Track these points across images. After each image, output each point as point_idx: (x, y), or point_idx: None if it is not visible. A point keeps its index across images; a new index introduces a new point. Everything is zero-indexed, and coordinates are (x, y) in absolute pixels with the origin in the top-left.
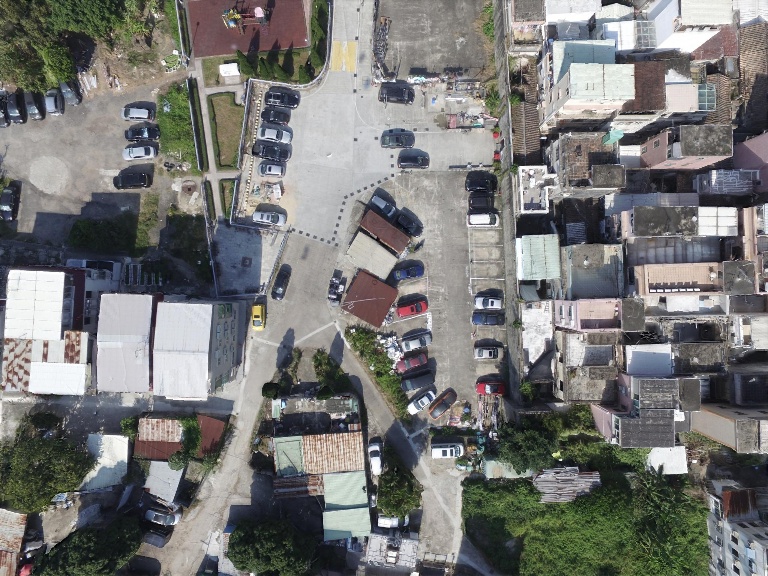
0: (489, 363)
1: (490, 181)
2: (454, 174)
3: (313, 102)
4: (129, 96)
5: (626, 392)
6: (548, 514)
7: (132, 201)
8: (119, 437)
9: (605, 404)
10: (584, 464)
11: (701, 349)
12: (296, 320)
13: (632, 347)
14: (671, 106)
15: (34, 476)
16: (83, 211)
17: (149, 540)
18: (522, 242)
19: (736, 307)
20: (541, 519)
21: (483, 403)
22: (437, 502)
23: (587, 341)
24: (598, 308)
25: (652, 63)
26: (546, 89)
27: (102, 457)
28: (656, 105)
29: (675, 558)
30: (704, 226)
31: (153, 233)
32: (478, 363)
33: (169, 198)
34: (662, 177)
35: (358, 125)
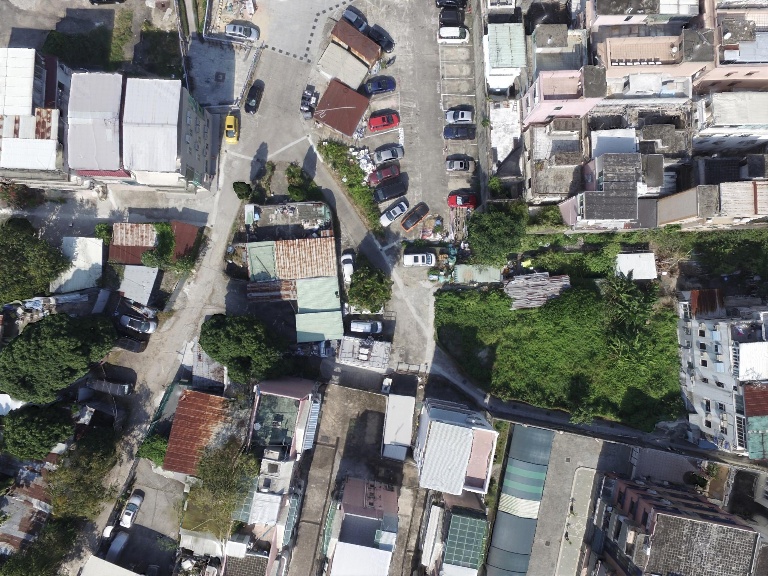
0: (461, 178)
1: None
2: None
3: None
4: None
5: (592, 178)
6: (519, 322)
7: (106, 17)
8: (93, 239)
9: None
10: (554, 270)
11: (664, 130)
12: (269, 134)
13: (597, 133)
14: None
15: (7, 258)
16: (58, 26)
17: (124, 344)
18: (488, 30)
19: None
20: (513, 327)
21: (455, 217)
22: (410, 313)
23: (553, 128)
24: (561, 84)
25: None
26: None
27: (77, 259)
28: None
29: (644, 354)
30: (665, 4)
31: (127, 48)
32: (450, 178)
33: (143, 14)
34: None
35: None
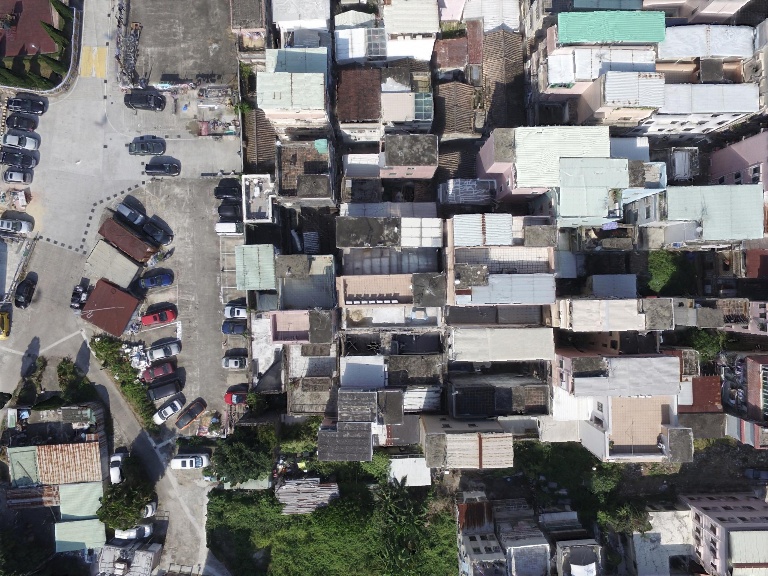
0: (240, 373)
1: (238, 189)
2: (206, 182)
3: (62, 108)
4: None
5: None
6: (293, 525)
7: None
8: None
9: (330, 416)
10: (326, 475)
11: (410, 361)
12: (42, 329)
13: (346, 359)
14: (386, 115)
15: None
16: None
17: None
18: (235, 252)
19: (469, 318)
20: (286, 531)
21: (233, 413)
22: (183, 513)
23: (301, 352)
24: (297, 320)
25: (368, 71)
26: None
27: None
28: (371, 114)
29: (406, 571)
30: (407, 237)
31: None
32: (229, 373)
33: None
34: (401, 186)
35: (108, 132)
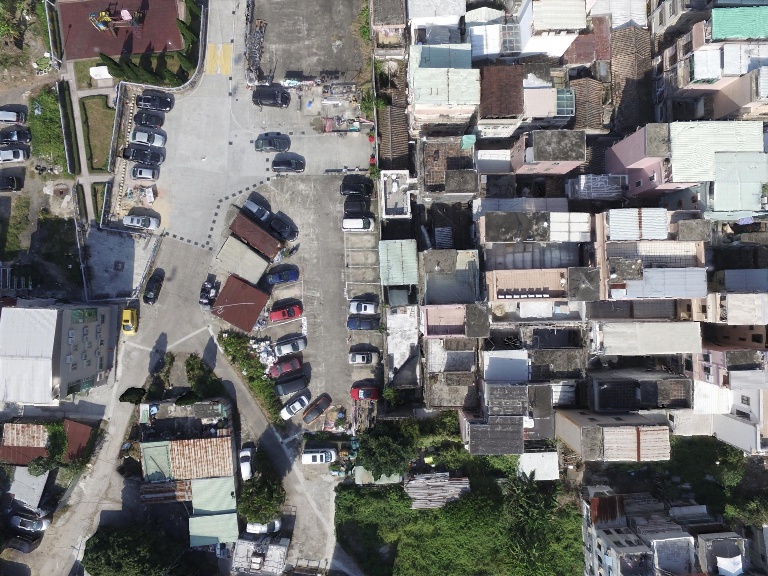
0: (365, 368)
1: (364, 185)
2: (330, 178)
3: (187, 105)
4: None
5: (484, 398)
6: (421, 520)
7: (3, 204)
8: None
9: (468, 410)
10: (455, 470)
11: (556, 355)
12: (169, 324)
13: (489, 353)
14: (529, 111)
15: None
16: None
17: (15, 546)
18: (379, 247)
19: (603, 313)
20: (413, 525)
21: (358, 408)
22: (310, 508)
23: (444, 347)
24: (448, 314)
25: (510, 67)
26: (410, 93)
27: None
28: (514, 110)
29: (541, 565)
30: (556, 232)
31: (24, 237)
32: (353, 368)
33: (41, 201)
34: (532, 182)
35: (233, 128)
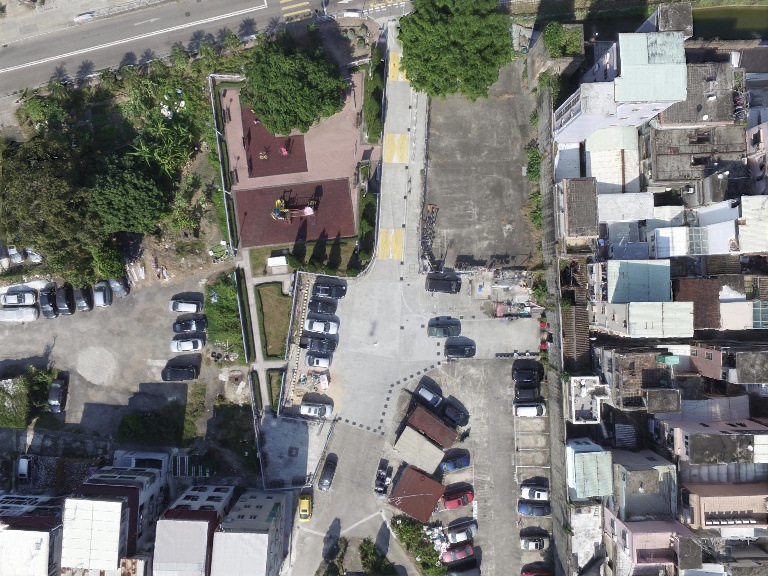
0: (534, 551)
1: (537, 372)
2: (500, 362)
3: (360, 290)
4: (177, 287)
5: None
6: None
7: (179, 392)
8: None
9: None
10: None
11: (754, 572)
12: (342, 510)
13: None
14: (725, 324)
15: None
16: (130, 402)
17: None
18: (575, 460)
19: None
20: None
21: None
22: None
23: None
24: (653, 538)
25: (707, 281)
26: (598, 296)
27: None
28: (710, 323)
29: None
30: (760, 454)
31: (200, 424)
32: (523, 551)
33: (216, 388)
34: None
35: (405, 313)
